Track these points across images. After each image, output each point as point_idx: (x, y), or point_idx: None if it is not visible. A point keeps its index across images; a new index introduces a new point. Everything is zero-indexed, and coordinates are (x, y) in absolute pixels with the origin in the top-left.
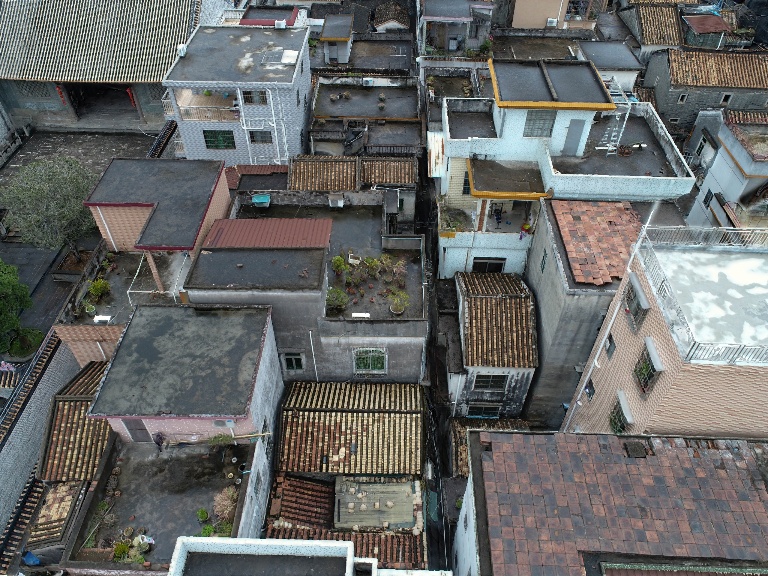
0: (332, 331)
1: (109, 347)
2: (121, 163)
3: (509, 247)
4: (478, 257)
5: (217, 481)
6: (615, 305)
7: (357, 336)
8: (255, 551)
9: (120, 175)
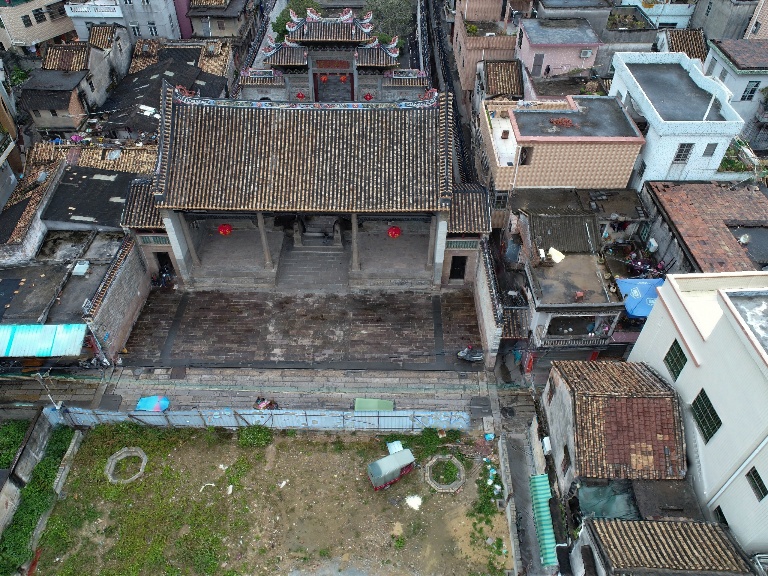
0: (608, 39)
1: (487, 54)
2: None
3: (681, 14)
4: (661, 23)
5: (579, 86)
6: (760, 5)
7: (619, 43)
8: (643, 60)
9: None
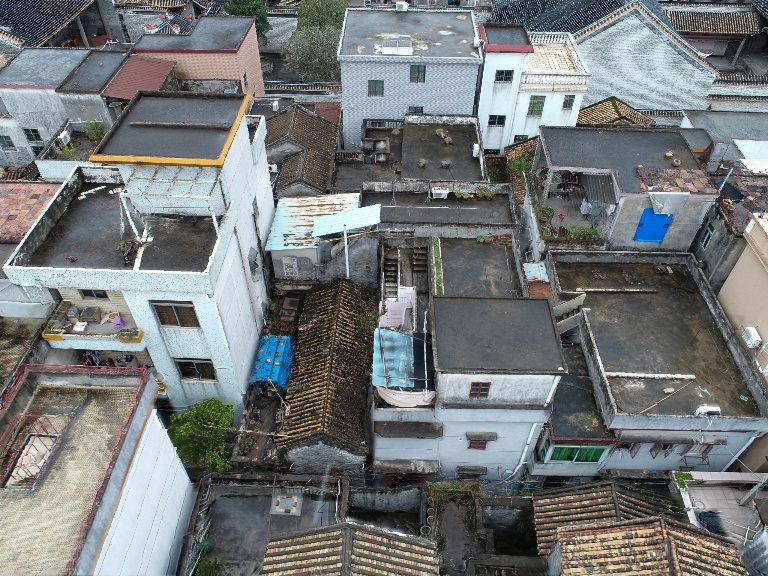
0: None
1: None
2: (246, 20)
3: None
4: None
5: None
6: None
7: None
8: None
9: (230, 21)
